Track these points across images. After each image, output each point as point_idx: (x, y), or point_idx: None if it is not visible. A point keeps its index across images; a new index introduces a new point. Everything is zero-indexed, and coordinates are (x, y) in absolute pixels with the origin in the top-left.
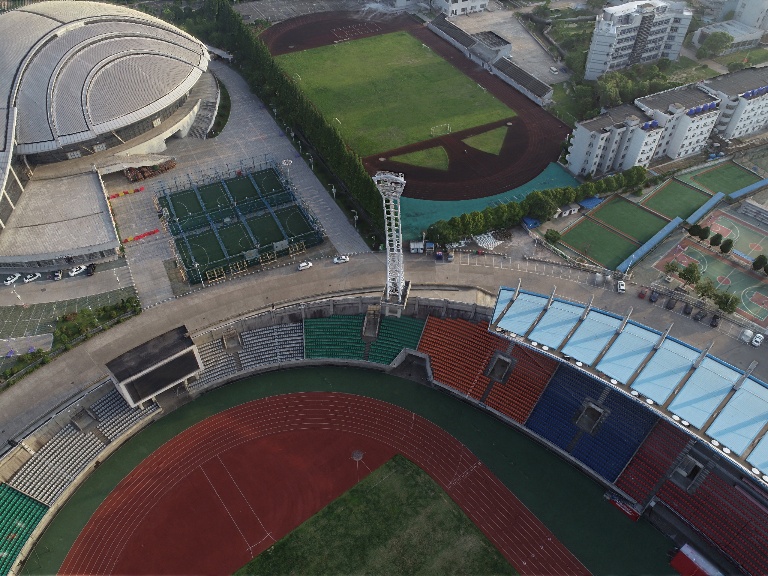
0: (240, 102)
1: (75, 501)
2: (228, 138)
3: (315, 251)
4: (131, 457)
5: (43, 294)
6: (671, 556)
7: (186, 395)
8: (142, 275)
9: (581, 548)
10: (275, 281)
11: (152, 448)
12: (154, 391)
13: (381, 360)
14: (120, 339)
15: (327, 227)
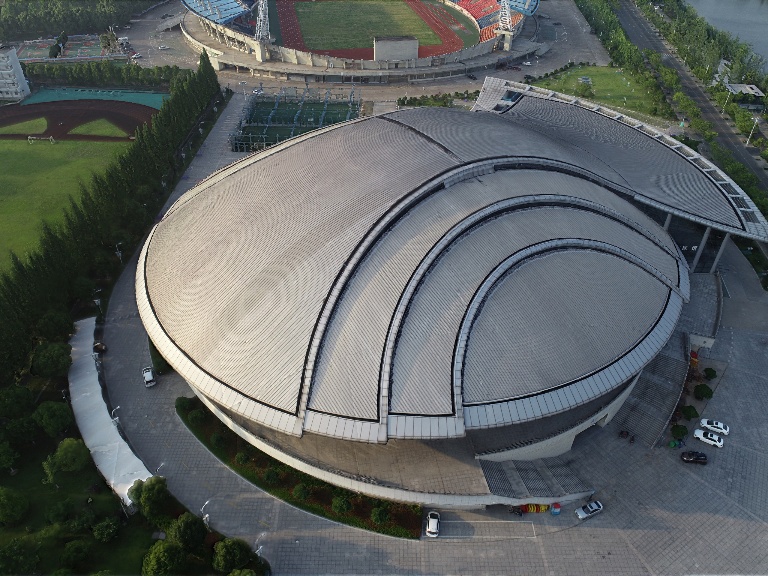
0: None
1: None
2: None
3: None
4: None
5: None
6: (253, 26)
7: None
8: None
9: (277, 31)
10: None
11: None
12: None
13: None
14: (414, 95)
15: None
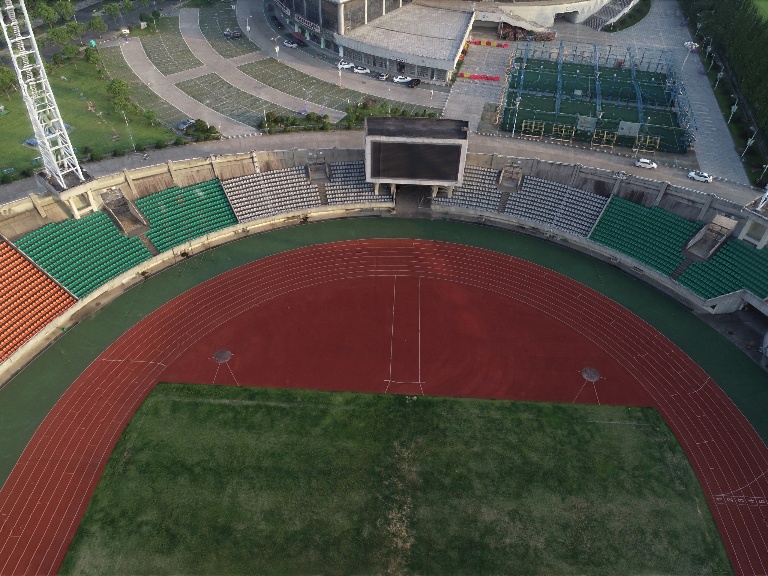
0: (660, 15)
1: (264, 237)
2: (626, 37)
3: (669, 157)
4: (337, 232)
5: (361, 85)
6: None
7: (427, 211)
8: (457, 105)
9: None
10: (598, 163)
11: (361, 235)
12: (397, 176)
13: (696, 289)
14: None
15: (700, 143)
